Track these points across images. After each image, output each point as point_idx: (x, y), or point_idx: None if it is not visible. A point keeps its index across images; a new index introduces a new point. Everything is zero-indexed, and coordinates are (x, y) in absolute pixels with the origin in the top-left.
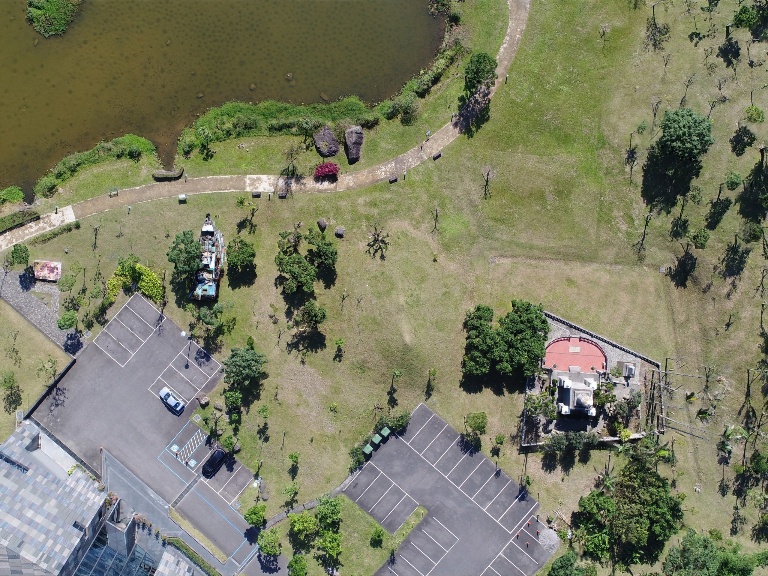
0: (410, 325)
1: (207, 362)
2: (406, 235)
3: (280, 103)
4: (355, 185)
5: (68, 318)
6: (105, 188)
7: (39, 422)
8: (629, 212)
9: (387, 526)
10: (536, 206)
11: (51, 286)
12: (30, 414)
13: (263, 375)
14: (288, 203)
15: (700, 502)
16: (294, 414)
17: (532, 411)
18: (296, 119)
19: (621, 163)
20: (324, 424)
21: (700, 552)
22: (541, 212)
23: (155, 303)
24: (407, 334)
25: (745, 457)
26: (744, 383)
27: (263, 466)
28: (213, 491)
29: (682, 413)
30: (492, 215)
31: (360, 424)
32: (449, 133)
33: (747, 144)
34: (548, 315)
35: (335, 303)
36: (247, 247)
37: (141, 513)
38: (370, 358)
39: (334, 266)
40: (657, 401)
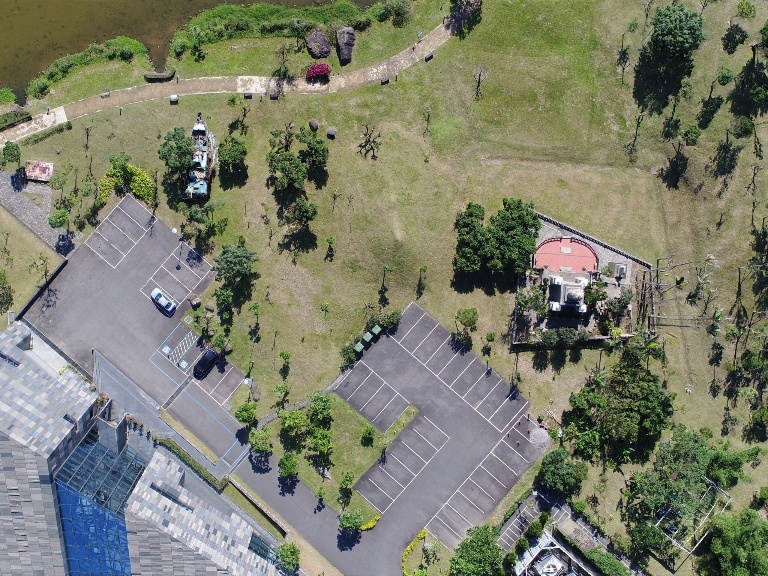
0: (401, 222)
1: (199, 263)
2: (398, 136)
3: (272, 5)
4: (347, 86)
5: (59, 215)
6: (97, 89)
7: (31, 323)
8: (621, 113)
9: (378, 425)
10: (528, 107)
11: (43, 187)
12: (22, 315)
13: (254, 275)
14: (280, 104)
15: (691, 403)
16: (285, 314)
17: (523, 305)
18: (288, 21)
19: (613, 64)
20: (315, 324)
21: (690, 445)
22: (533, 113)
23: (147, 204)
24: (398, 231)
25: (736, 357)
26: (735, 282)
27: (254, 367)
28: (204, 392)
29: (673, 314)
30: (484, 116)
31: (351, 323)
32: (441, 35)
33: (739, 42)
34: (539, 216)
35: (326, 203)
36: (238, 145)
37: (132, 413)
38: (361, 257)
39: (325, 165)
40: (648, 302)
